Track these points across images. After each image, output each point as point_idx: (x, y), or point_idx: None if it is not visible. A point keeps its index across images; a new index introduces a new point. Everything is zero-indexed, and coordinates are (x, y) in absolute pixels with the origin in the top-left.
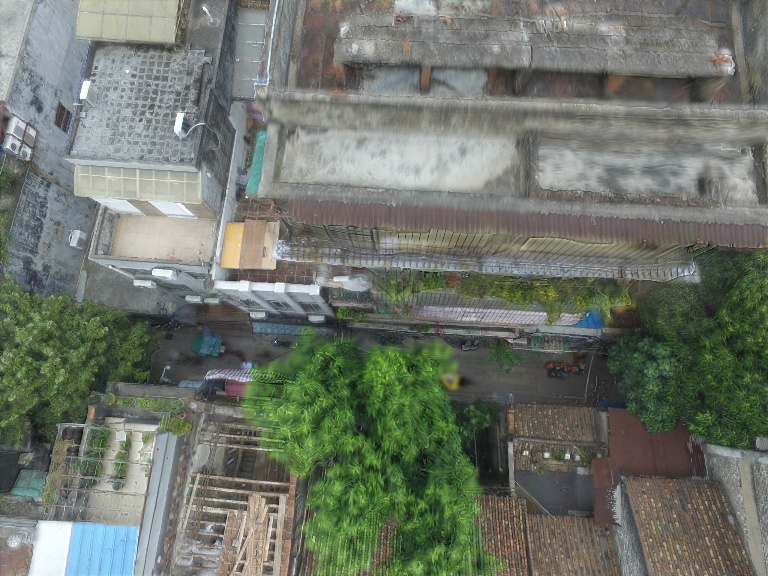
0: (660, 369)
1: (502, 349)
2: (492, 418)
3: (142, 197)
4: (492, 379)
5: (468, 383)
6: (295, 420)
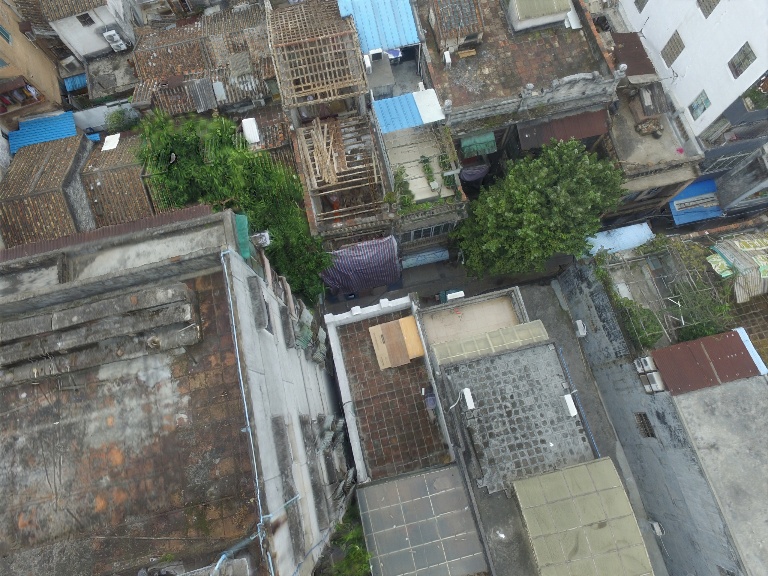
0: None
1: None
2: None
3: (483, 335)
4: None
5: None
6: (251, 172)
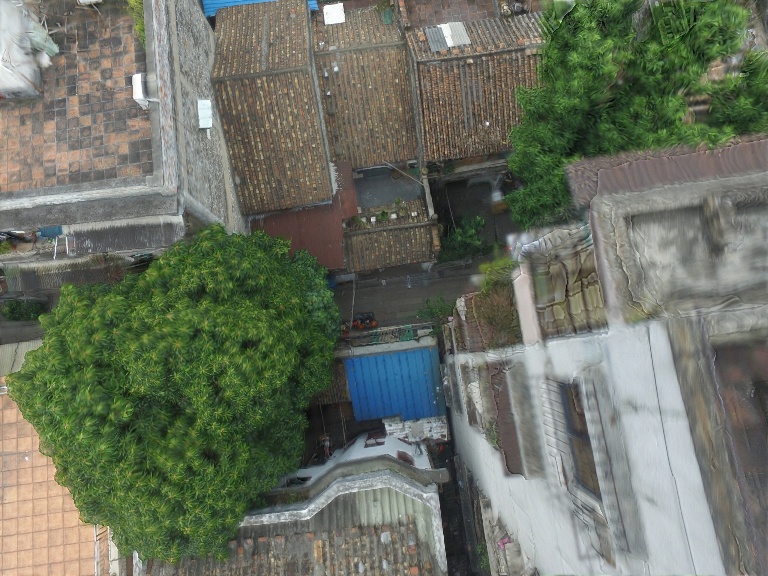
0: (321, 297)
1: (449, 315)
2: (444, 246)
3: None
4: (430, 299)
5: (455, 290)
6: None
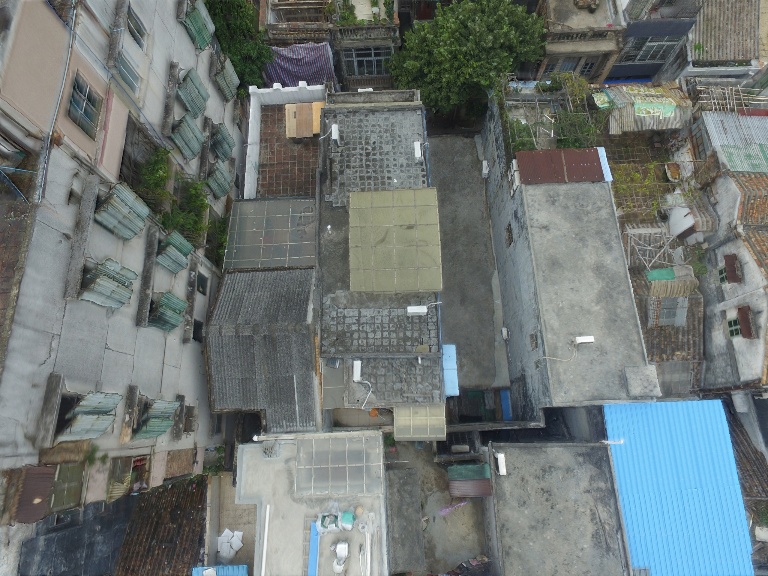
0: None
1: None
2: None
3: (370, 104)
4: None
5: None
6: None
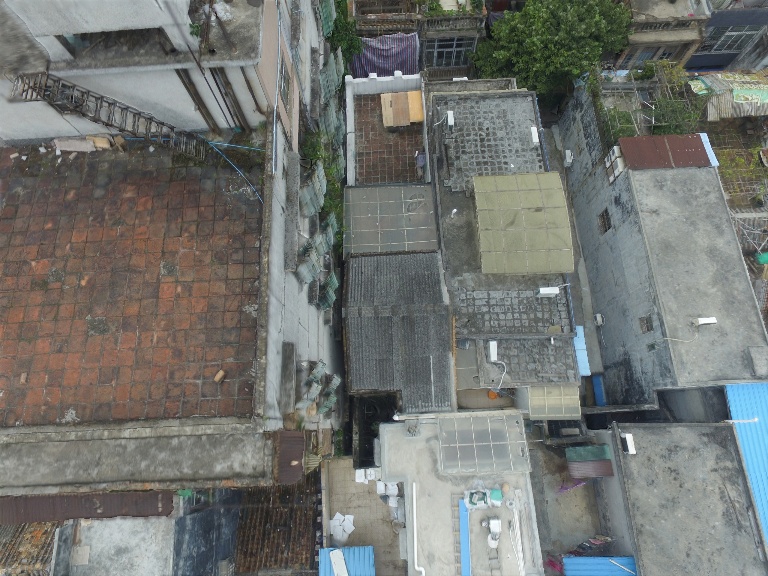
0: None
1: None
2: None
3: (475, 92)
4: None
5: None
6: None
